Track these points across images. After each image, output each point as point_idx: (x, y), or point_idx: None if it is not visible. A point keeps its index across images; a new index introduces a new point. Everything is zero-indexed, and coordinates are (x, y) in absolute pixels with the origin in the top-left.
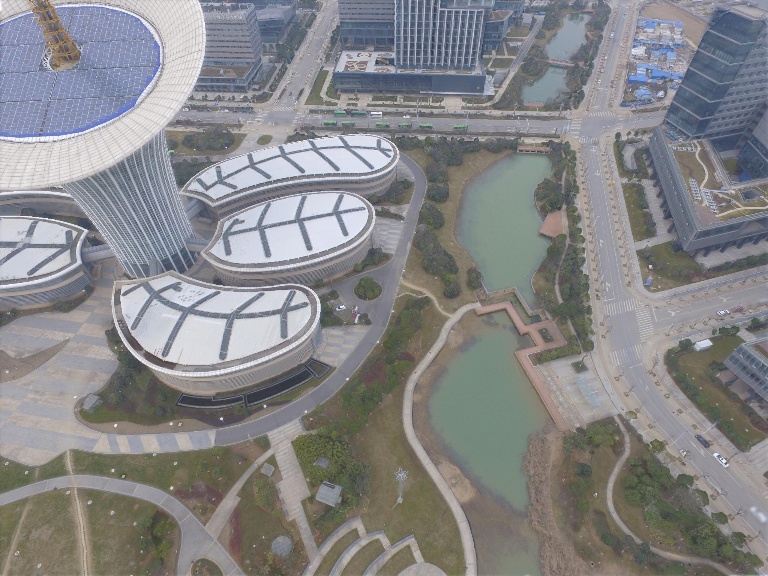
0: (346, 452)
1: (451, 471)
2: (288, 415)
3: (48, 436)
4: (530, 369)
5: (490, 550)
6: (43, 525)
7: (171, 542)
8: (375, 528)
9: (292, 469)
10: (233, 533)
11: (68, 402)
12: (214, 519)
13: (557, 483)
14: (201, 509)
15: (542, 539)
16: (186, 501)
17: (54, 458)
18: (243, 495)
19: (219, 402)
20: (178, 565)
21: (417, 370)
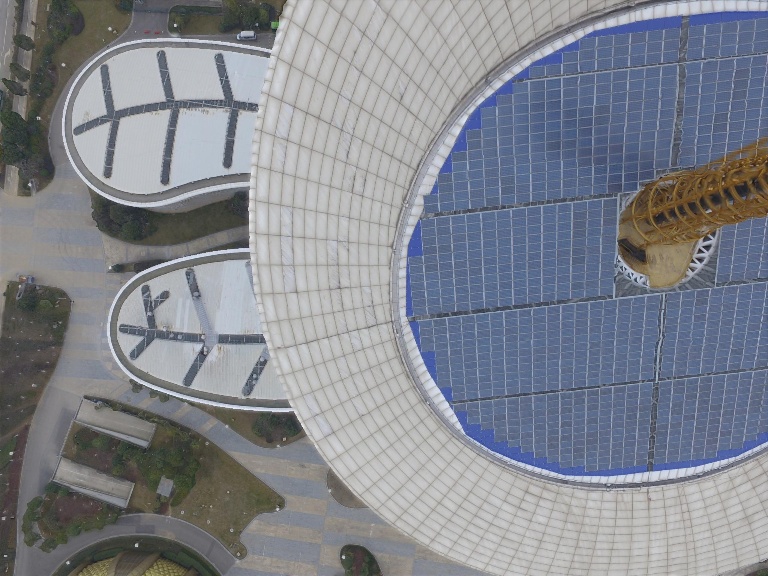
0: None
1: None
2: None
3: (472, 574)
4: None
5: None
6: None
7: None
8: None
9: None
10: None
11: None
12: None
13: None
14: None
15: None
16: None
17: None
18: None
19: None
20: None
21: None
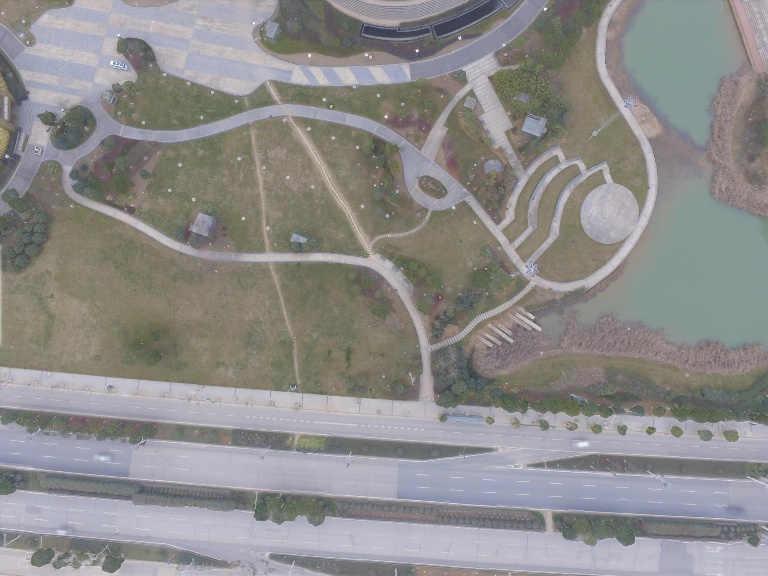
0: (549, 87)
1: (641, 110)
2: (481, 50)
3: (240, 66)
4: (739, 4)
5: (669, 176)
6: (275, 147)
7: (395, 162)
8: (573, 155)
9: (492, 103)
10: (448, 156)
11: (243, 30)
12: (428, 145)
13: (742, 122)
14: (414, 136)
15: (717, 168)
16: (398, 130)
17: (256, 88)
18: (450, 126)
19: (406, 34)
20: (405, 180)
21: (613, 2)
